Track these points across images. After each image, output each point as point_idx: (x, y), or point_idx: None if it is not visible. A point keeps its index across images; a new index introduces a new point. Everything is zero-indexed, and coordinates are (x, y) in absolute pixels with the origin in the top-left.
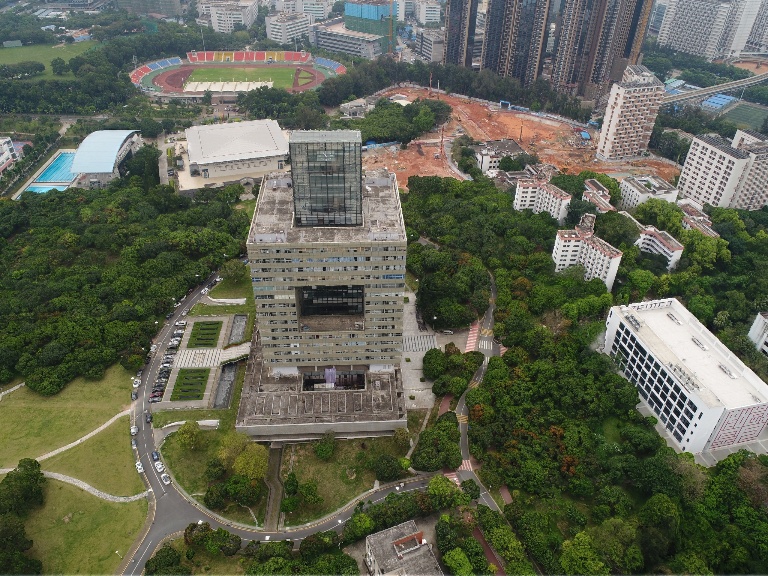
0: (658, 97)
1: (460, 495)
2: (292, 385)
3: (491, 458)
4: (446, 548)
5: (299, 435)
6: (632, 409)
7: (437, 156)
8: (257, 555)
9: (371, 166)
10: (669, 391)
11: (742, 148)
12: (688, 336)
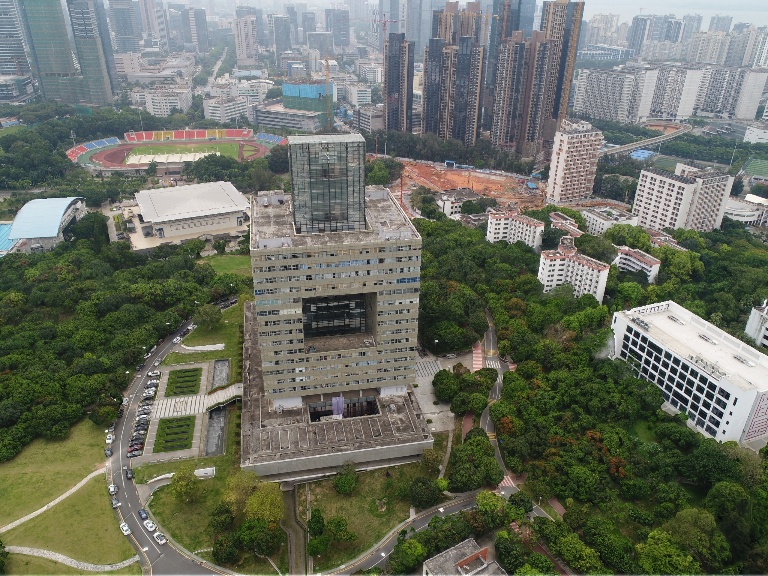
0: (598, 142)
1: (512, 509)
2: (298, 417)
3: (535, 467)
4: (514, 566)
5: (313, 471)
6: (659, 409)
7: None
8: None
9: None
10: (694, 384)
11: (688, 175)
12: (694, 334)
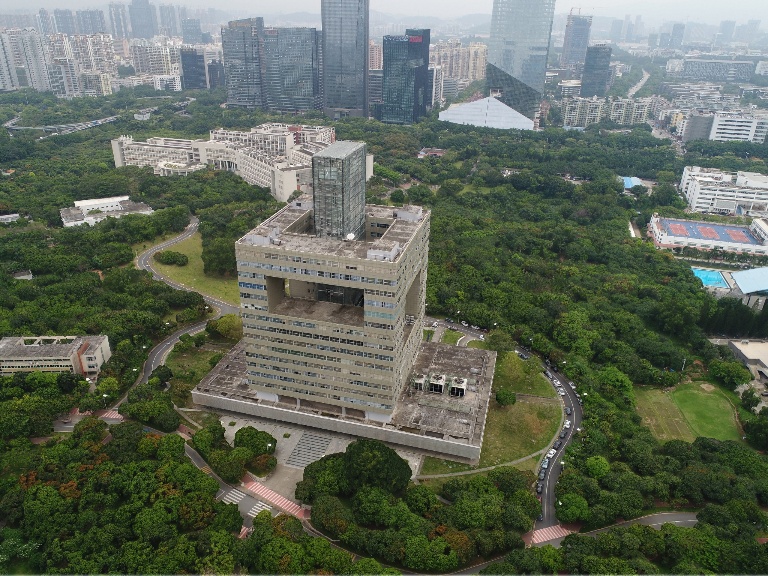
0: None
1: (92, 398)
2: None
3: None
4: None
5: None
6: None
7: None
8: None
9: None
10: None
11: None
12: None
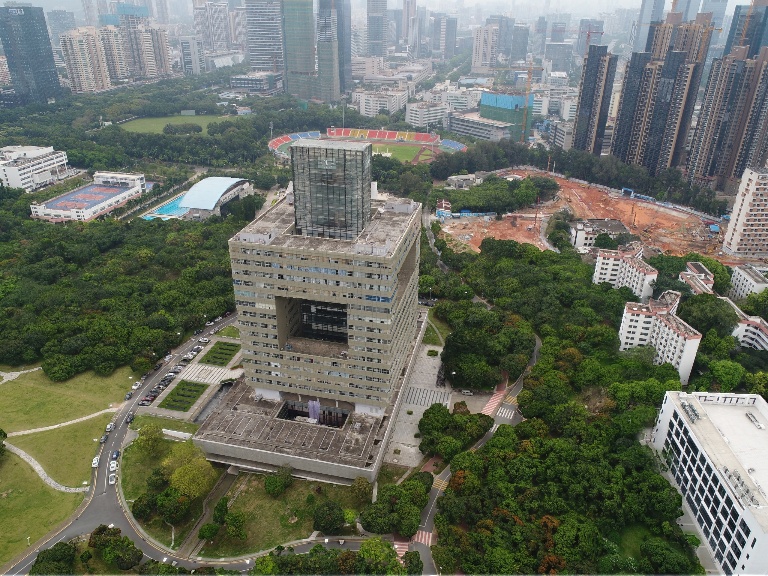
0: None
1: (396, 567)
2: (268, 410)
3: (451, 533)
4: None
5: (257, 464)
6: (668, 521)
7: (530, 228)
8: None
9: (458, 231)
10: (720, 504)
11: None
12: None
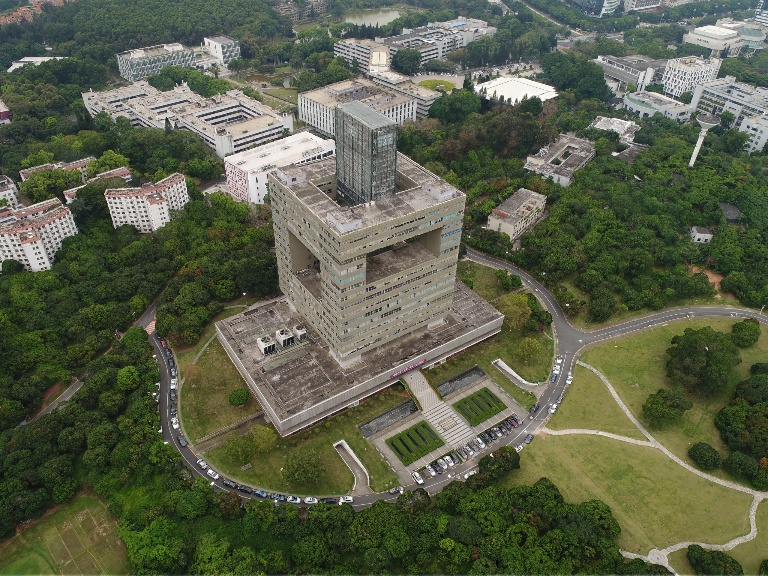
0: None
1: None
2: None
3: None
4: None
5: None
6: None
7: None
8: (555, 273)
9: None
10: None
11: None
12: (258, 159)
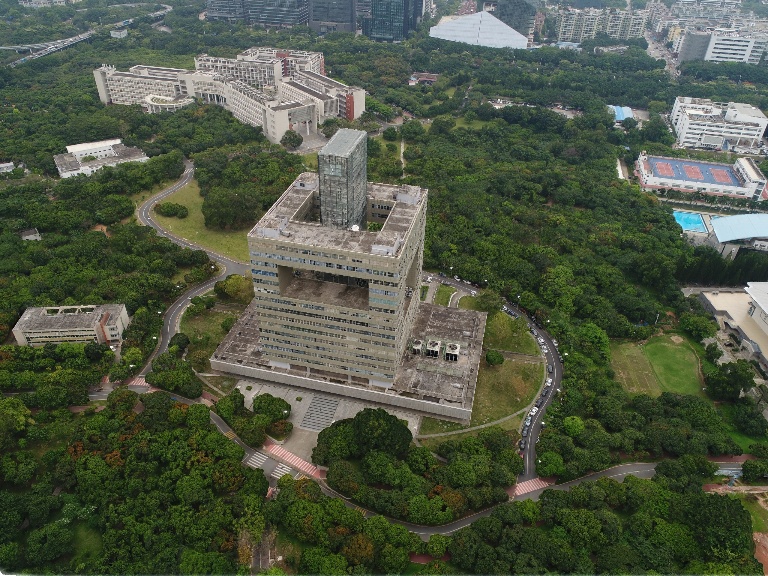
0: None
1: (119, 368)
2: None
3: None
4: None
5: None
6: (84, 569)
7: None
8: None
9: None
10: None
11: None
12: None
